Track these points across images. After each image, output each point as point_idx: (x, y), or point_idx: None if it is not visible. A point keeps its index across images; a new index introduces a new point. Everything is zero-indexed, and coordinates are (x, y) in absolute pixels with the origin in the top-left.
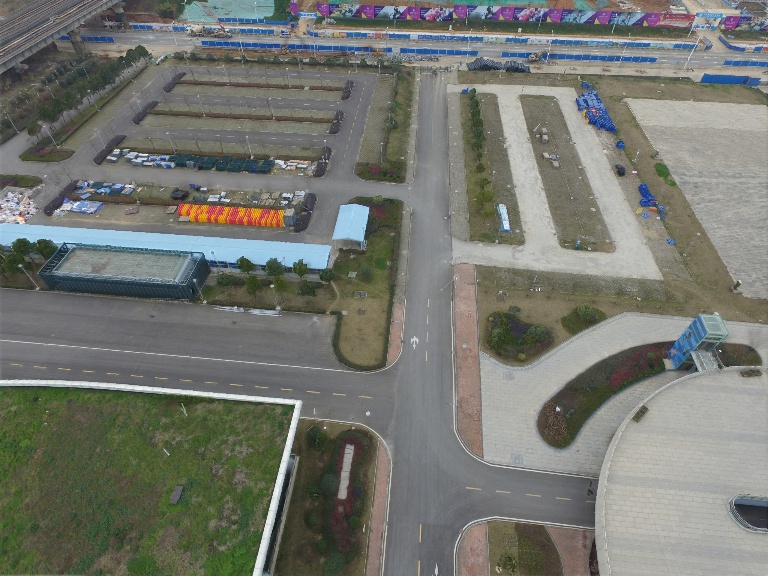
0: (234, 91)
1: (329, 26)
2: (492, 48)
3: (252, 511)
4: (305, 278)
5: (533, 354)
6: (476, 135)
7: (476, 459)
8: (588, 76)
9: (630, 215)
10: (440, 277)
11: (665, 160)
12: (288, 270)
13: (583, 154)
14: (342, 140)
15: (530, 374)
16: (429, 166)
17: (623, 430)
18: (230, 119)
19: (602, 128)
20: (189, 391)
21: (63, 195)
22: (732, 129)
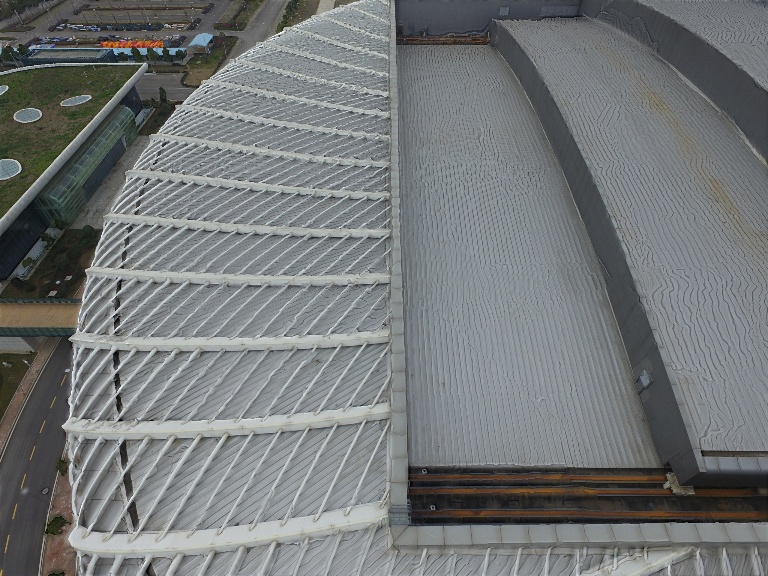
0: None
1: None
2: None
3: (120, 84)
4: None
5: None
6: None
7: None
8: None
9: None
10: None
11: None
12: (161, 58)
13: None
14: (210, 16)
15: None
16: (261, 24)
17: None
18: (138, 10)
19: None
20: (96, 63)
21: (30, 42)
22: None
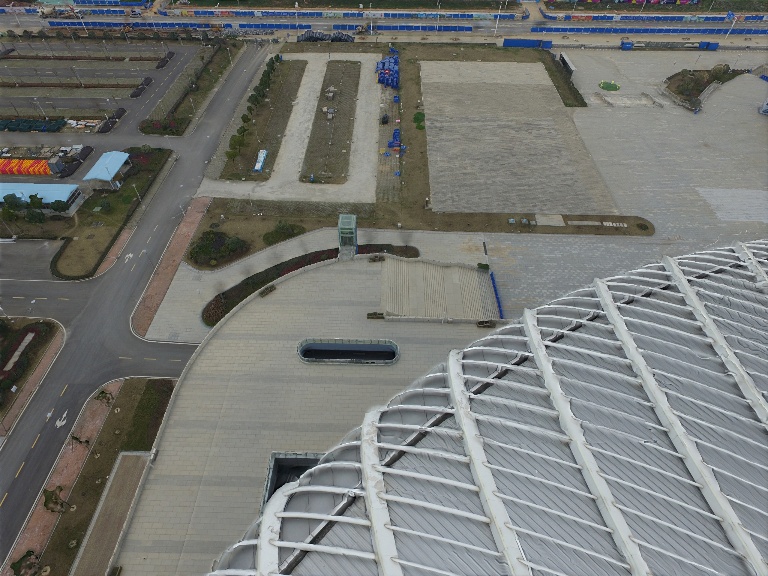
0: (56, 64)
1: (182, 6)
2: (328, 22)
3: None
4: (52, 213)
5: (225, 261)
6: (257, 92)
7: (138, 338)
8: (399, 43)
9: (374, 155)
10: (177, 208)
11: (426, 109)
12: None
13: (360, 108)
14: (140, 102)
15: (216, 276)
16: (212, 121)
17: (242, 302)
18: (41, 88)
19: (389, 86)
20: None
21: None
22: (500, 83)
